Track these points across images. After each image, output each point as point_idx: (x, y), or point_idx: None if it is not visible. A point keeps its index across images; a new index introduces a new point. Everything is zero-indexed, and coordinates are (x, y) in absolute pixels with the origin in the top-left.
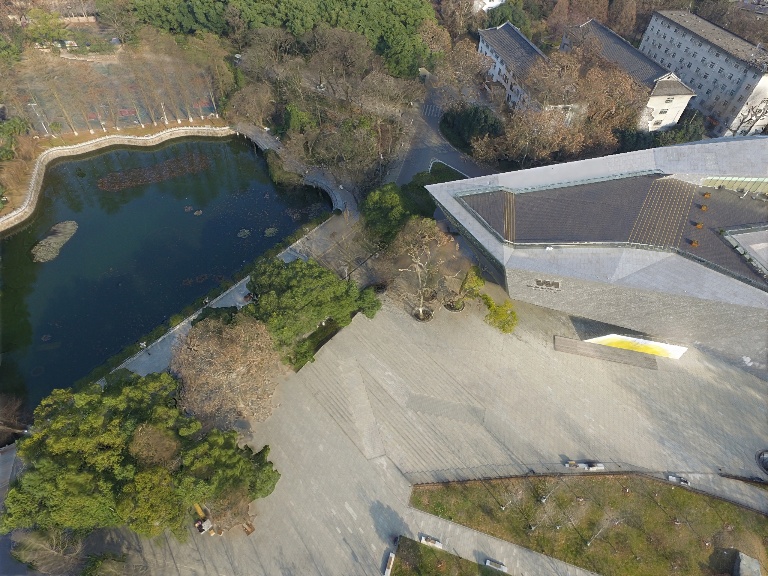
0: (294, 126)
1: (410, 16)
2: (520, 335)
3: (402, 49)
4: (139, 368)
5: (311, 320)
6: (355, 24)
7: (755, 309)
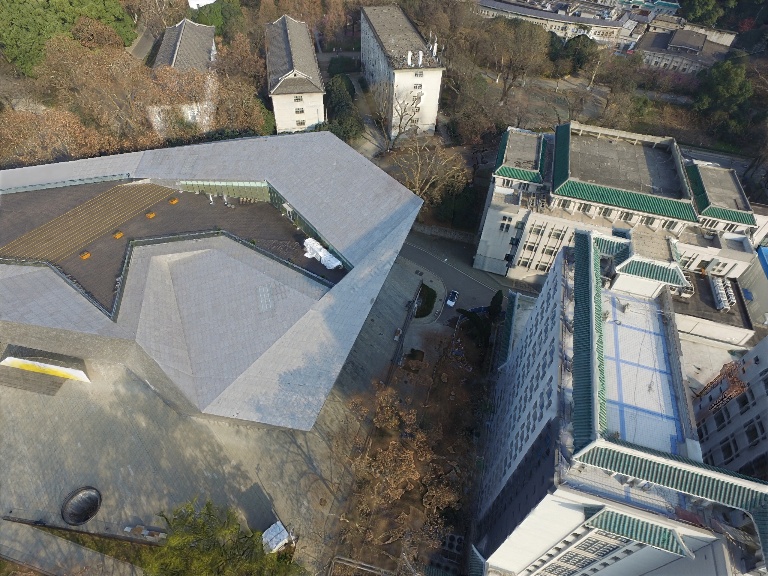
0: None
1: (68, 13)
2: None
3: (31, 48)
4: None
5: None
6: (5, 22)
7: (62, 330)
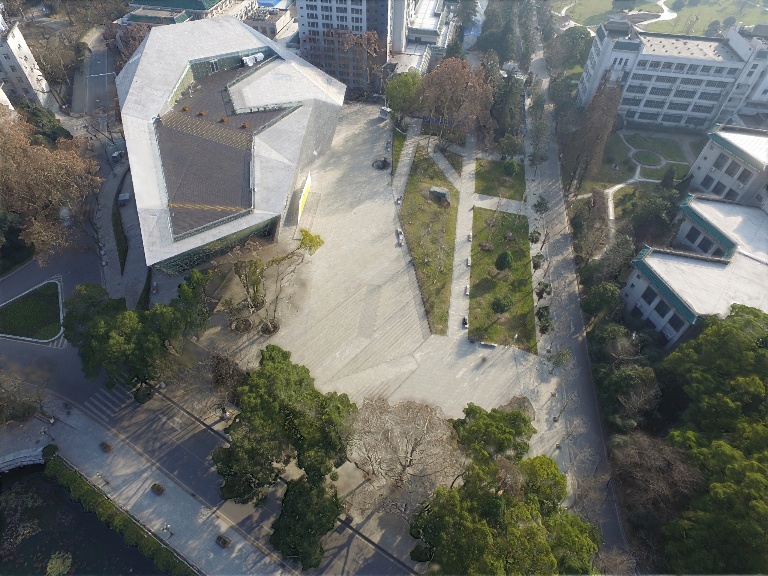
0: None
1: None
2: (293, 259)
3: None
4: None
5: None
6: None
7: None
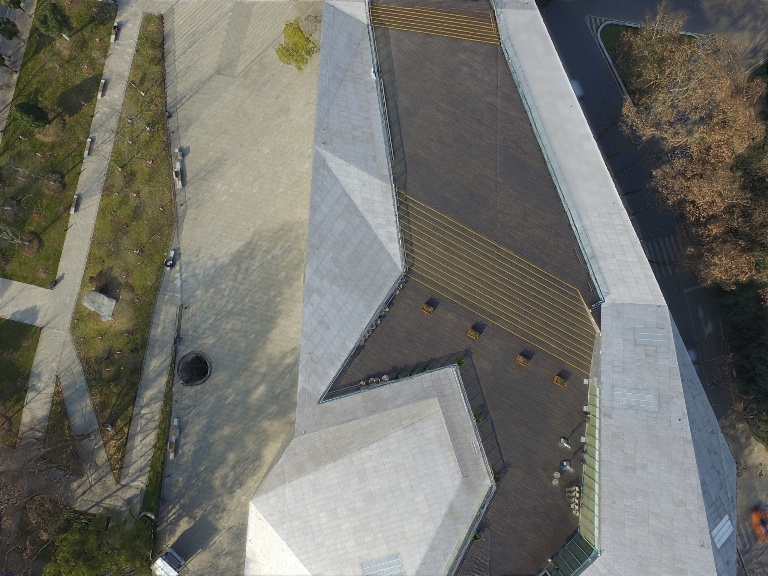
0: None
1: None
2: None
3: None
4: None
5: None
6: None
7: None
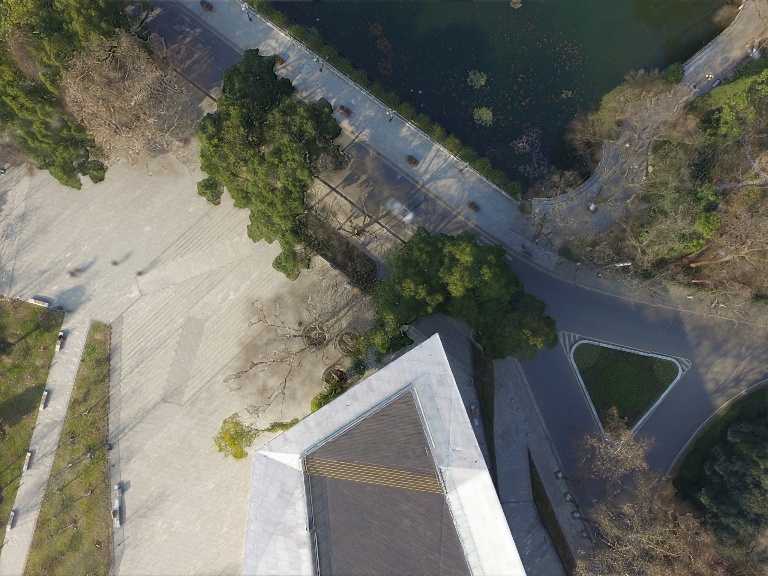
0: (715, 95)
1: None
2: None
3: None
4: (232, 15)
5: (233, 190)
6: None
7: None
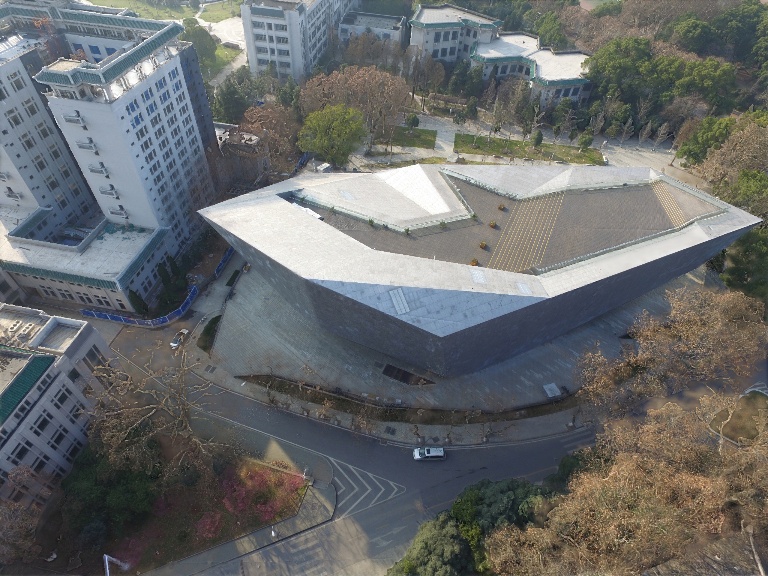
0: None
1: None
2: None
3: None
4: None
5: None
6: None
7: None
